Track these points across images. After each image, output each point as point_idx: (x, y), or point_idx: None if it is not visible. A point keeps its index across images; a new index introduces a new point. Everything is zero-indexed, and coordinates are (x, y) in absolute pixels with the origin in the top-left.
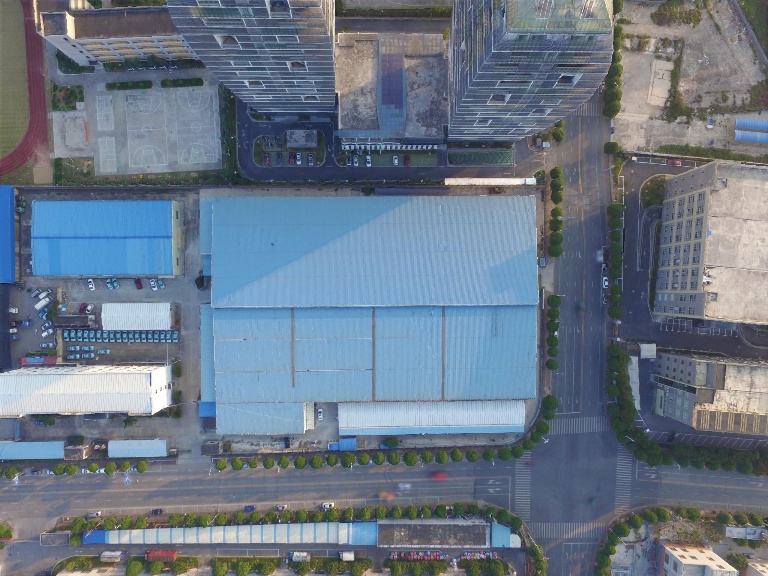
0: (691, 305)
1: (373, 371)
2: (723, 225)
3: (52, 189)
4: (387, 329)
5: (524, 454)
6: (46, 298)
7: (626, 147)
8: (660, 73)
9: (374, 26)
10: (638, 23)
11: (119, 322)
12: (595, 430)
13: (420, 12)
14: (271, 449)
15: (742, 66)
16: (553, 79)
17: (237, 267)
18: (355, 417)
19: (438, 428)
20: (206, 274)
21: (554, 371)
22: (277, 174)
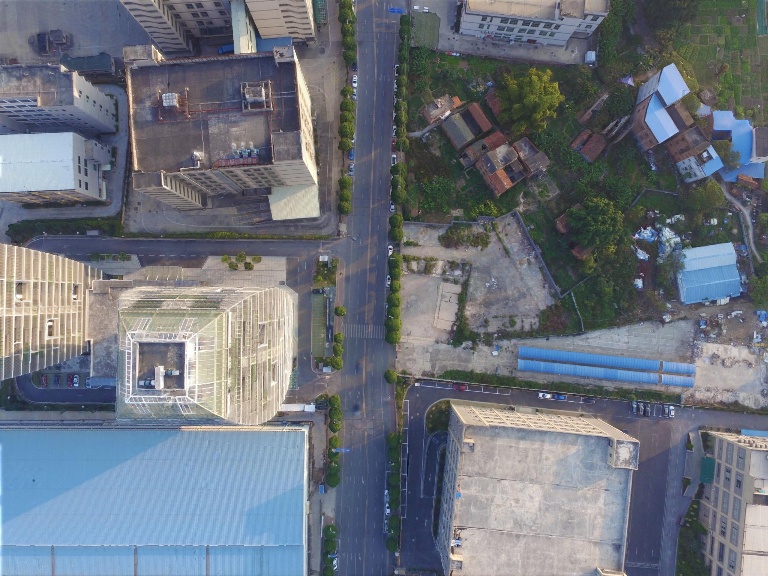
0: (446, 563)
1: None
2: (475, 485)
3: None
4: (149, 567)
5: None
6: None
7: (411, 371)
8: (447, 296)
9: (157, 247)
10: (425, 245)
11: None
12: None
13: None
14: None
15: (531, 290)
16: None
17: None
18: None
19: None
20: None
21: None
22: (55, 396)
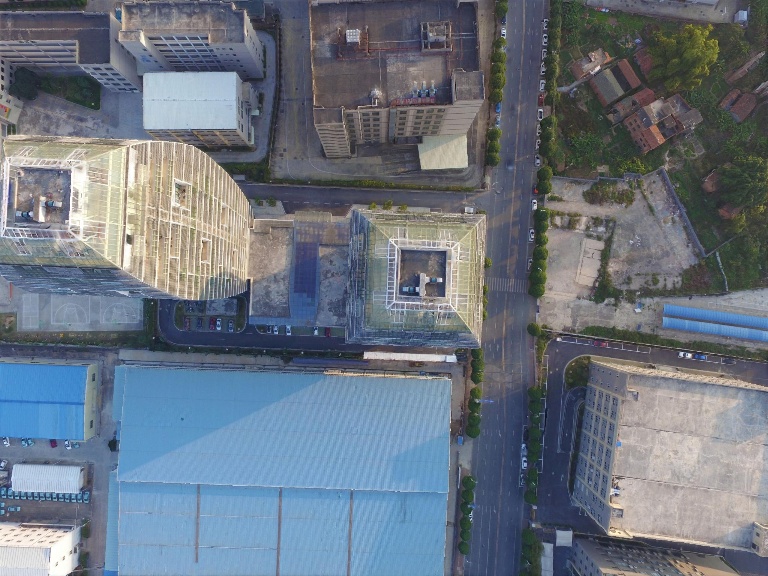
0: (600, 513)
1: (278, 550)
2: (635, 435)
3: None
4: (294, 509)
5: None
6: None
7: (552, 326)
8: (590, 252)
9: (302, 194)
10: (569, 201)
11: (29, 484)
12: None
13: (347, 184)
14: None
15: (674, 249)
16: None
17: (145, 441)
18: None
19: None
20: (119, 438)
21: (465, 556)
22: (197, 338)
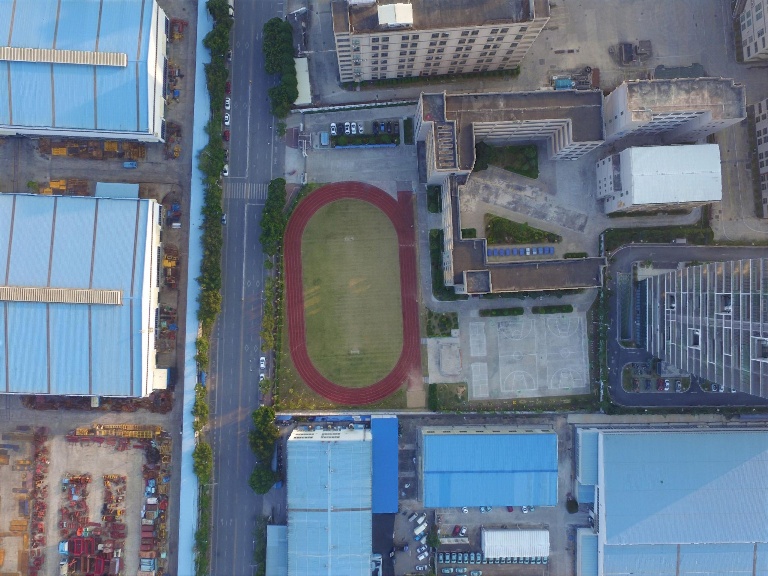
0: None
1: None
2: None
3: None
4: (767, 562)
5: None
6: (424, 523)
7: None
8: None
9: (738, 254)
10: None
11: (501, 551)
12: None
13: None
14: None
15: None
16: None
17: (629, 505)
18: None
19: None
20: (581, 501)
21: None
22: (645, 400)
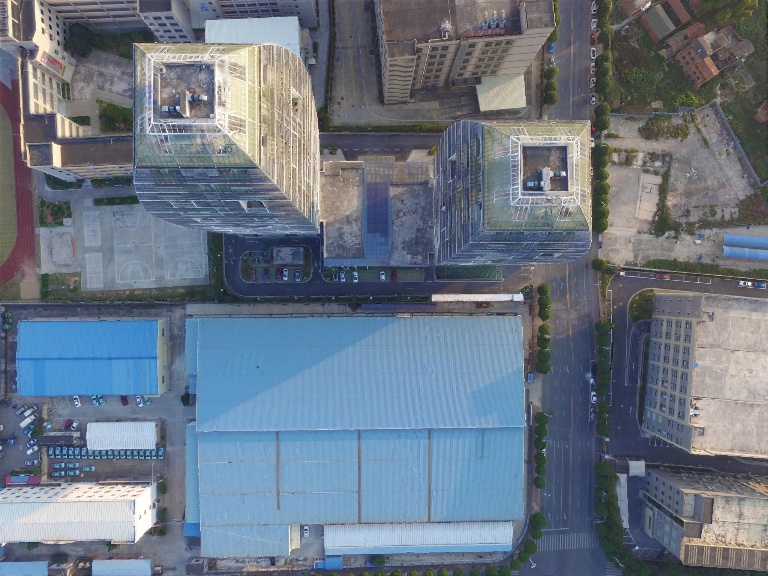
0: (678, 435)
1: (359, 493)
2: (710, 356)
3: (39, 305)
4: (373, 451)
5: (512, 571)
6: (31, 416)
7: (614, 261)
8: (648, 187)
9: (361, 141)
10: (626, 137)
11: (104, 442)
12: (584, 546)
13: (407, 129)
14: (256, 566)
15: (730, 180)
16: (533, 255)
17: (222, 390)
18: (341, 537)
19: (425, 547)
20: (192, 392)
21: (542, 490)
22: (264, 290)
